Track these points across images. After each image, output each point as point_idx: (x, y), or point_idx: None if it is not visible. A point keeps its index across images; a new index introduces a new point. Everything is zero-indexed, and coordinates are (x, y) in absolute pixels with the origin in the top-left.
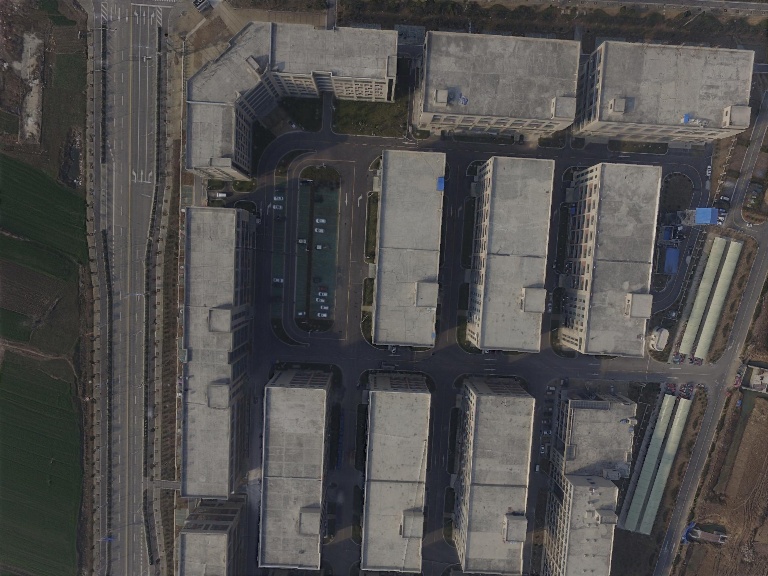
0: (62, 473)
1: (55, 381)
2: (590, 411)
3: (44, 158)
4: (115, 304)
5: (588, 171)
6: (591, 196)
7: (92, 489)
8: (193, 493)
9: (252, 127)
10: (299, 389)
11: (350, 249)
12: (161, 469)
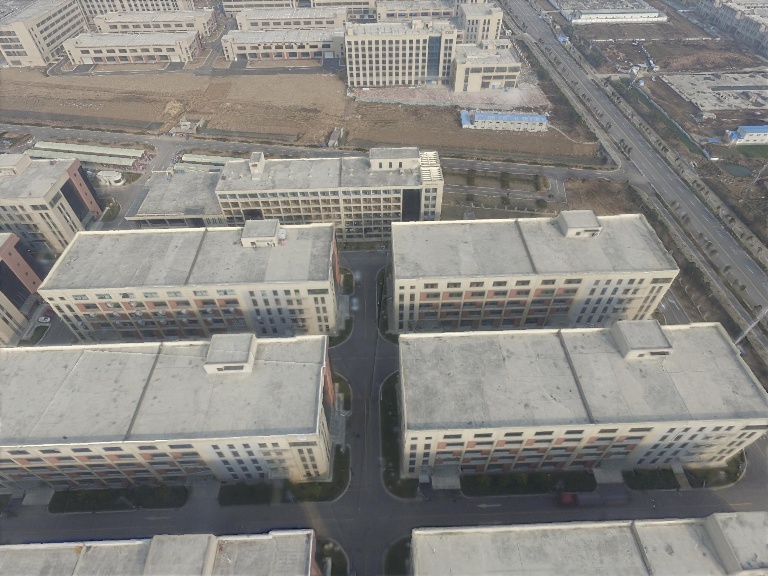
0: None
1: None
2: (146, 202)
3: None
4: None
5: None
6: None
7: None
8: None
9: None
10: None
11: None
12: None
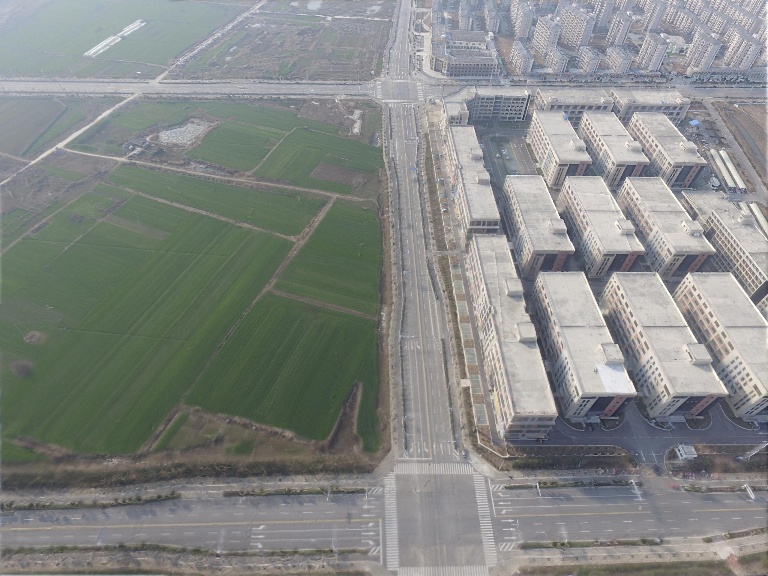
0: (369, 250)
1: (365, 210)
2: (697, 195)
3: (362, 138)
4: (400, 180)
5: (629, 124)
6: (637, 125)
7: (391, 255)
8: (477, 218)
9: None
10: (526, 176)
11: (523, 159)
12: (437, 245)
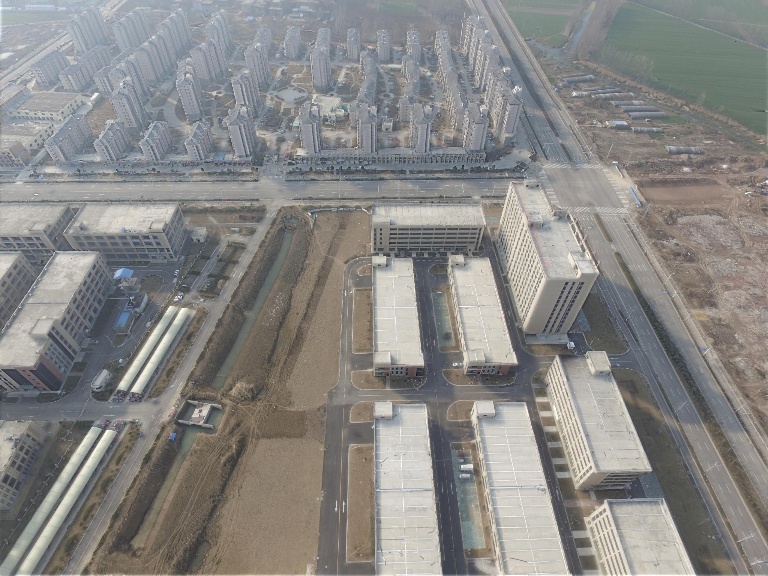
0: None
1: None
2: None
3: None
4: None
5: None
6: None
7: None
8: None
9: None
10: None
11: None
12: None
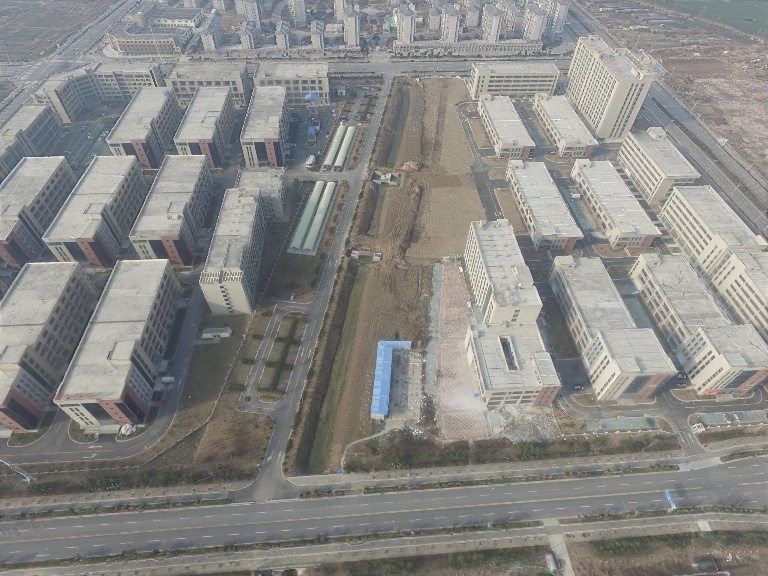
0: None
1: None
2: (252, 174)
3: None
4: None
5: None
6: None
7: None
8: None
9: (82, 109)
10: (47, 158)
11: None
12: None
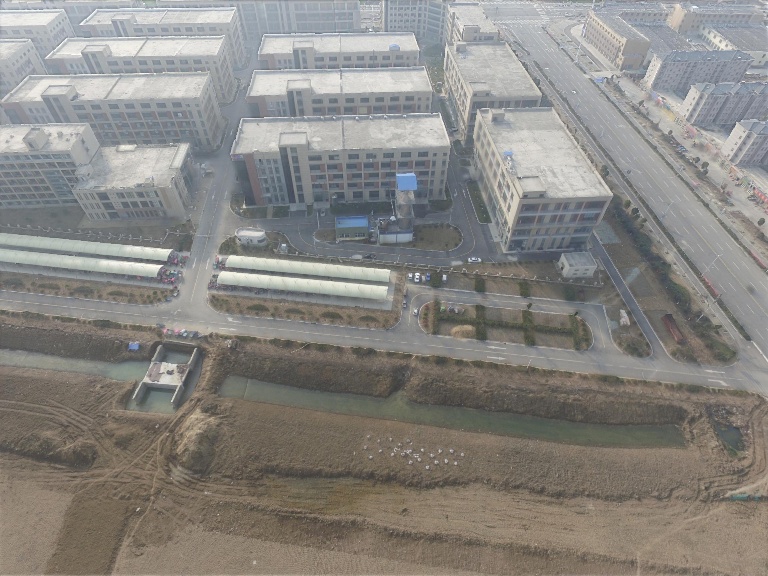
0: None
1: None
2: (172, 156)
3: None
4: None
5: None
6: None
7: None
8: None
9: (418, 38)
10: None
11: None
12: None
